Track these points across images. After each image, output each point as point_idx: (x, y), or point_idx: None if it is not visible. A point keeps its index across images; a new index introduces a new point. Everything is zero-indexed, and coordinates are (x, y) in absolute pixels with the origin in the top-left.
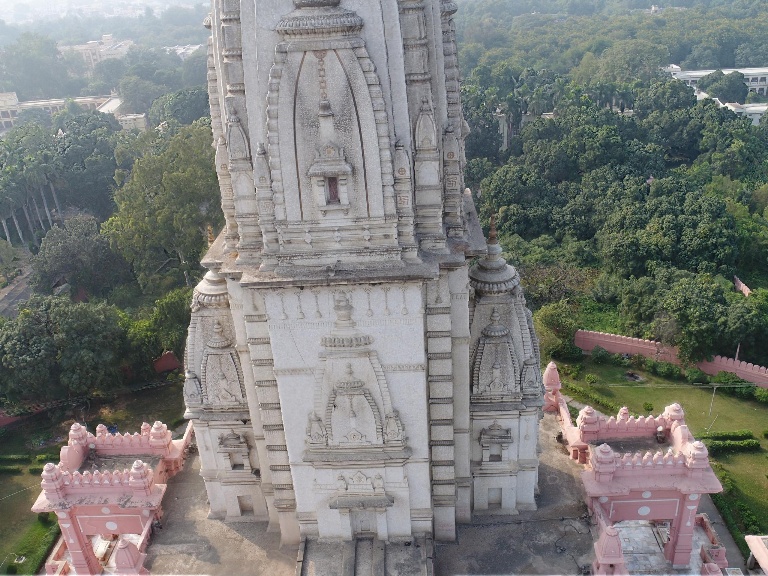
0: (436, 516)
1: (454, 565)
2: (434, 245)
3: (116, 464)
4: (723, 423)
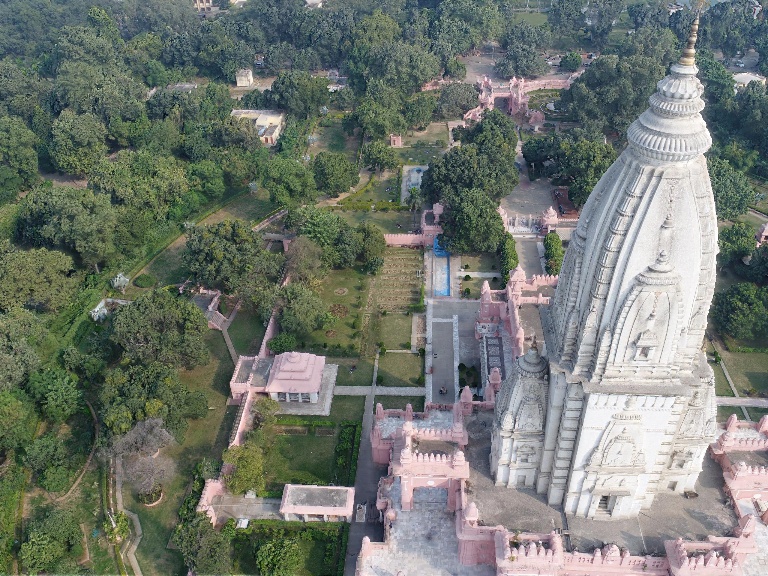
0: None
1: None
2: None
3: (760, 466)
4: None
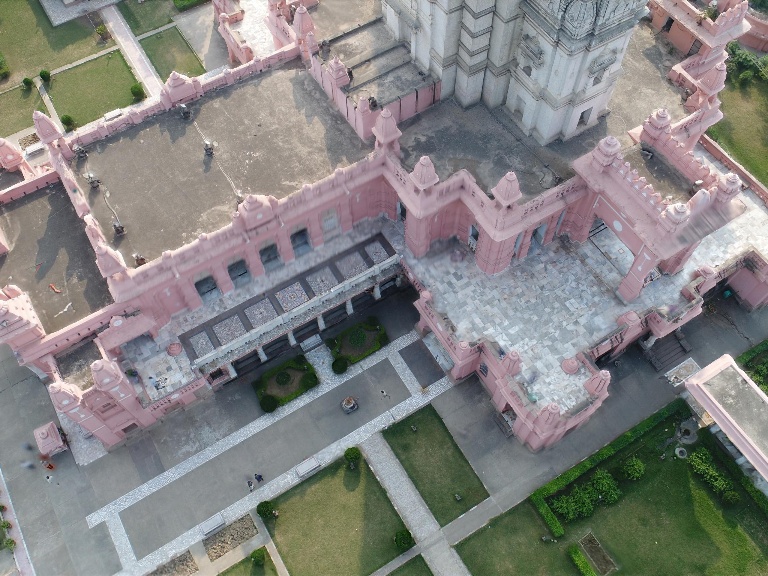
0: (458, 75)
1: (442, 117)
2: None
3: None
4: None
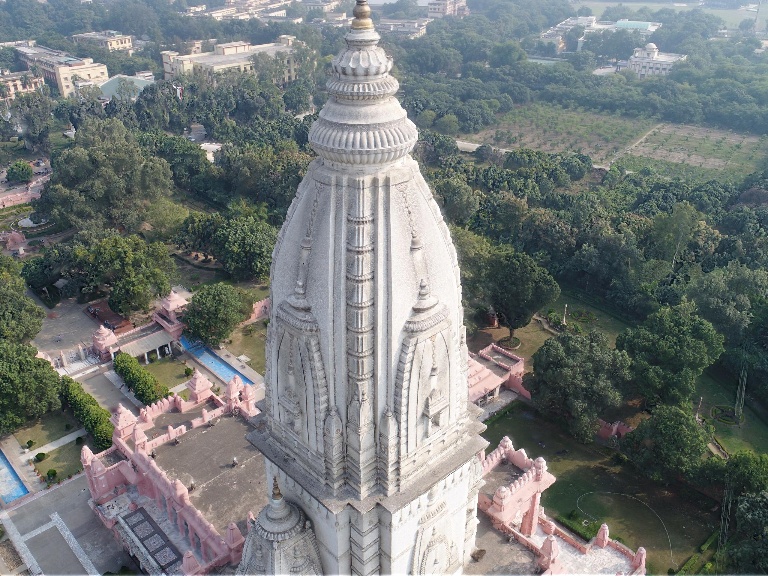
0: None
1: None
2: None
3: (508, 482)
4: None
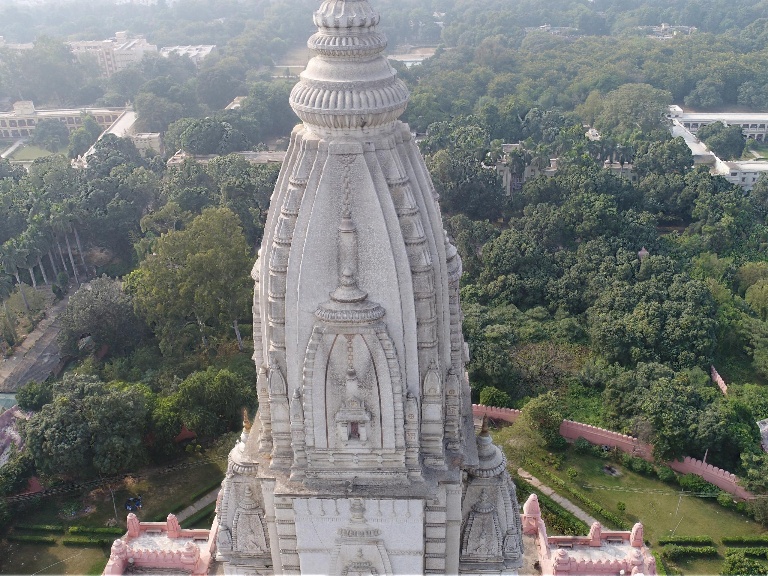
0: None
1: None
2: (435, 462)
3: None
4: (687, 526)
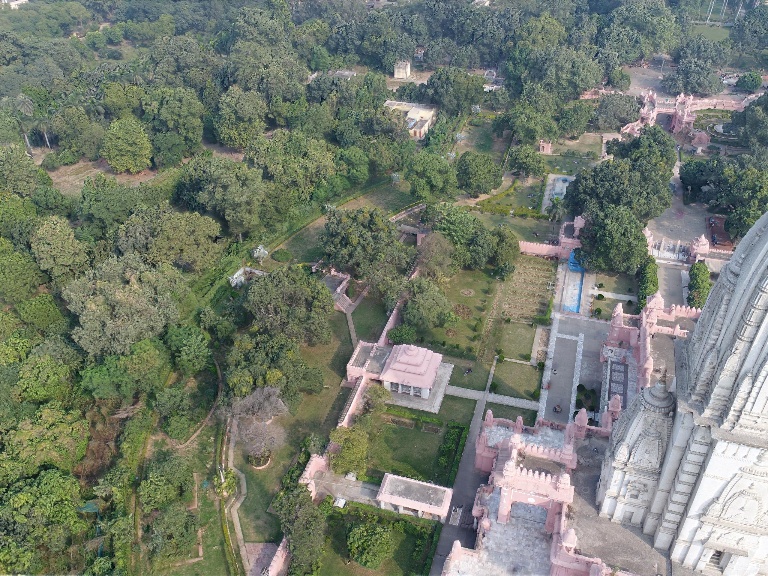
0: None
1: None
2: None
3: None
4: None
